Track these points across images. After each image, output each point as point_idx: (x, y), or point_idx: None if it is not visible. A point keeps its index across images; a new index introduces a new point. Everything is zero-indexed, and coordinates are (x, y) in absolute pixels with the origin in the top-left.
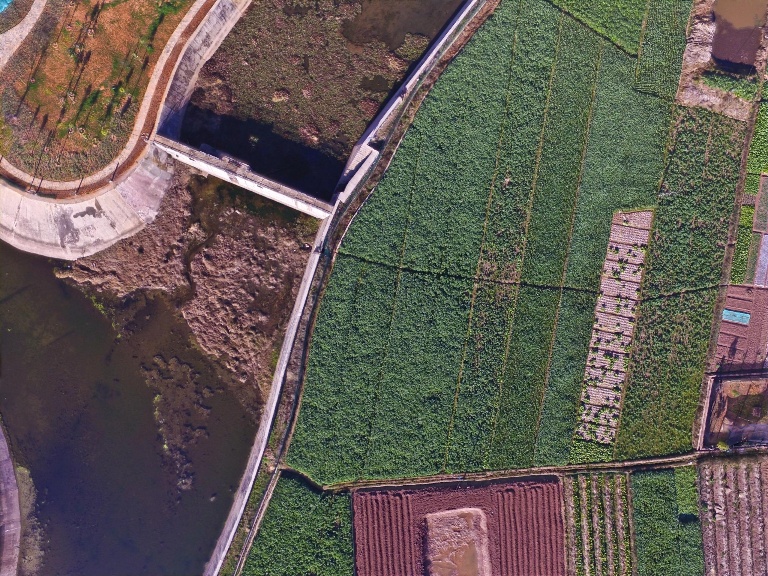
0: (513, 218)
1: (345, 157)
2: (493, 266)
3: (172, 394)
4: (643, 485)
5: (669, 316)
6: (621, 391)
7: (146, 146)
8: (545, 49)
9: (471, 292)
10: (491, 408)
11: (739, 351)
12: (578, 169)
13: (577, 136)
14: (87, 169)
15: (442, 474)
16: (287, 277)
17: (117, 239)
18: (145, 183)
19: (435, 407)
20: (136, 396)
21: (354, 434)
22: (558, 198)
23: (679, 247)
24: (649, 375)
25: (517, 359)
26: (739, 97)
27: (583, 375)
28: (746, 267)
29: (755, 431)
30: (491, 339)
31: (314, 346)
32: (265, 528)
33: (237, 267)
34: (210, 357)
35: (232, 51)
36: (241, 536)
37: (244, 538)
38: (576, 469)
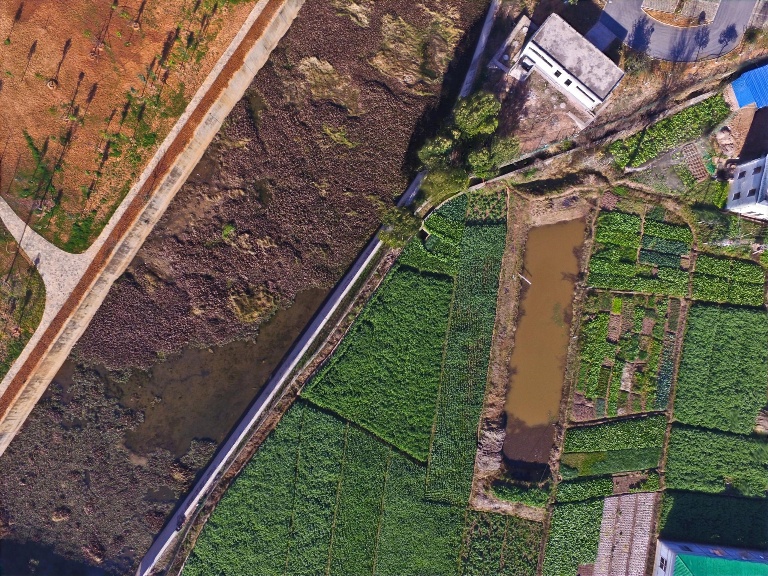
0: None
1: (131, 573)
2: None
3: None
4: None
5: None
6: None
7: None
8: (330, 464)
9: None
10: None
11: None
12: None
13: (366, 552)
14: None
15: None
16: None
17: None
18: None
19: None
20: None
21: None
22: None
23: None
24: None
25: None
26: (530, 505)
27: None
28: None
29: None
30: None
31: None
32: None
33: None
34: None
35: (8, 471)
36: None
37: None
38: None
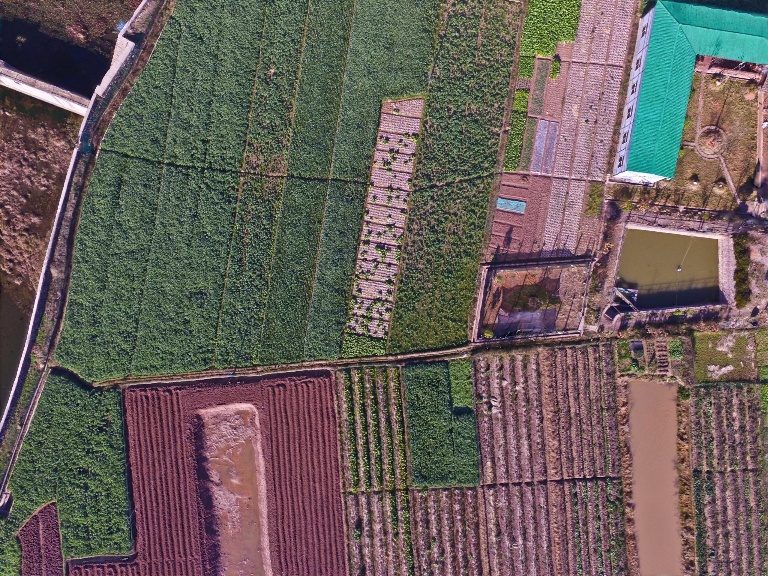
0: (278, 109)
1: None
2: (259, 159)
3: None
4: (415, 378)
5: (442, 206)
6: (394, 284)
7: None
8: None
9: (237, 186)
10: (260, 303)
11: (515, 240)
12: (344, 57)
13: (342, 23)
14: None
15: (212, 370)
16: (59, 178)
17: None
18: None
19: (202, 302)
20: None
21: (121, 330)
22: (323, 87)
23: (450, 135)
24: (422, 267)
25: (285, 253)
26: None
27: (353, 268)
28: (519, 153)
29: (532, 322)
30: (258, 233)
31: (78, 243)
32: (33, 424)
33: (8, 169)
34: None
35: None
36: (13, 433)
37: (16, 435)
38: (348, 363)
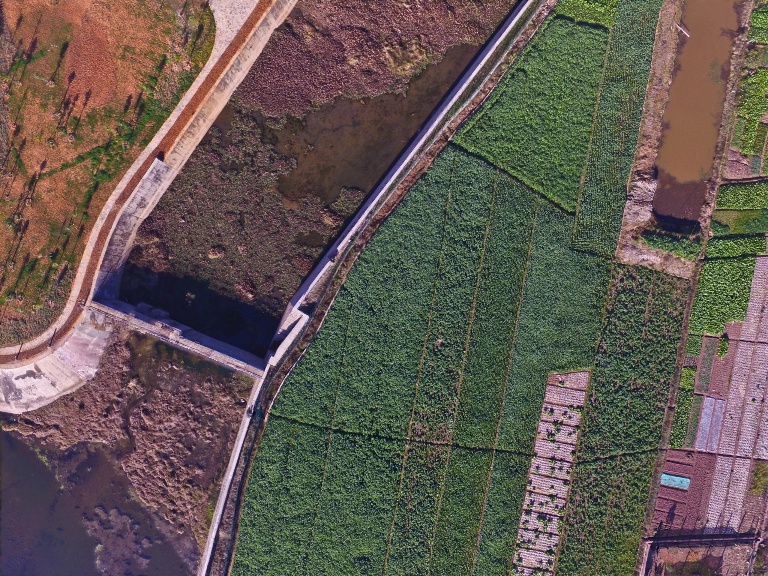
0: (445, 379)
1: (280, 313)
2: (425, 427)
3: (113, 544)
4: None
5: (605, 479)
6: (555, 554)
7: (82, 312)
8: (479, 208)
9: (402, 453)
10: (422, 569)
11: (678, 516)
12: (512, 330)
13: (511, 297)
14: (26, 335)
15: None
16: (223, 431)
17: (59, 395)
18: (83, 345)
19: (365, 568)
20: (79, 545)
21: None
22: (491, 360)
23: (616, 410)
24: (584, 539)
25: (448, 521)
26: (680, 257)
27: (515, 538)
28: (686, 432)
29: None
30: (422, 501)
31: (246, 506)
32: None
33: (174, 422)
34: (149, 509)
35: (169, 208)
36: None
37: None
38: None
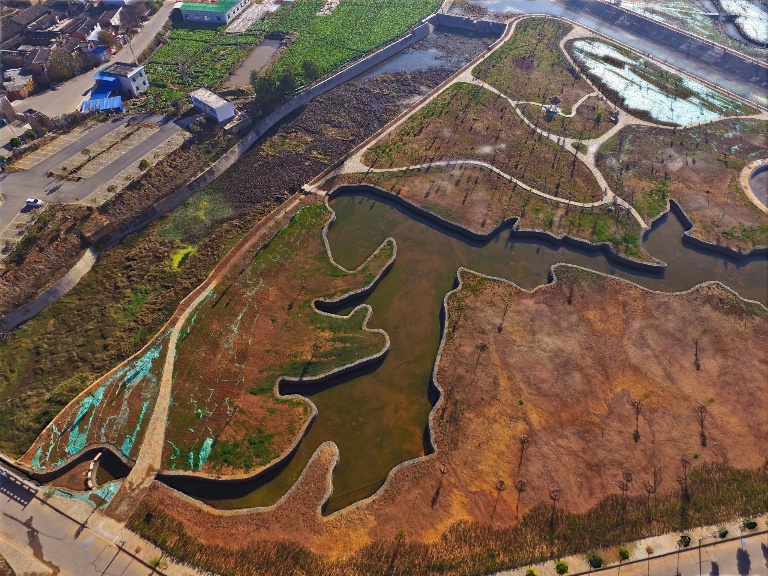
0: None
1: None
2: None
3: None
4: None
5: None
6: None
7: (510, 22)
8: None
9: None
10: None
11: None
12: None
13: None
14: None
15: None
16: None
17: None
18: None
19: None
20: (500, 0)
21: None
22: None
23: None
24: None
25: None
26: None
27: None
28: None
29: None
30: None
31: None
32: None
33: None
34: None
35: None
36: None
37: None
38: None
